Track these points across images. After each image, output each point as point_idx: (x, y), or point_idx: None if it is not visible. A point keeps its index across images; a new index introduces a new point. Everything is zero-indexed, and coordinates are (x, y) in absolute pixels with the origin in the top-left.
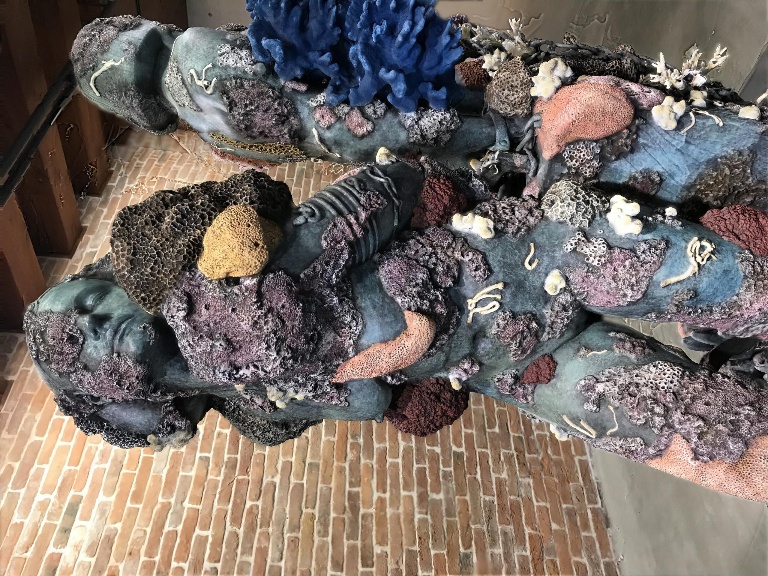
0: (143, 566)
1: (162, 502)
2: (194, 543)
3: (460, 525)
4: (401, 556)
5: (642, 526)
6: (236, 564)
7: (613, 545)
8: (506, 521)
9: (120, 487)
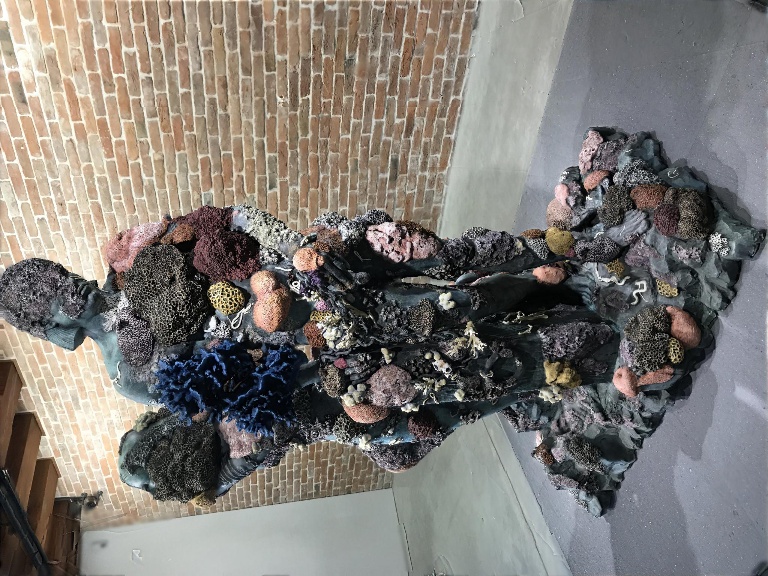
0: (90, 79)
1: (82, 22)
2: (125, 58)
3: (349, 36)
4: (298, 63)
5: (490, 65)
6: (165, 74)
7: (472, 44)
8: (389, 30)
9: (36, 11)
